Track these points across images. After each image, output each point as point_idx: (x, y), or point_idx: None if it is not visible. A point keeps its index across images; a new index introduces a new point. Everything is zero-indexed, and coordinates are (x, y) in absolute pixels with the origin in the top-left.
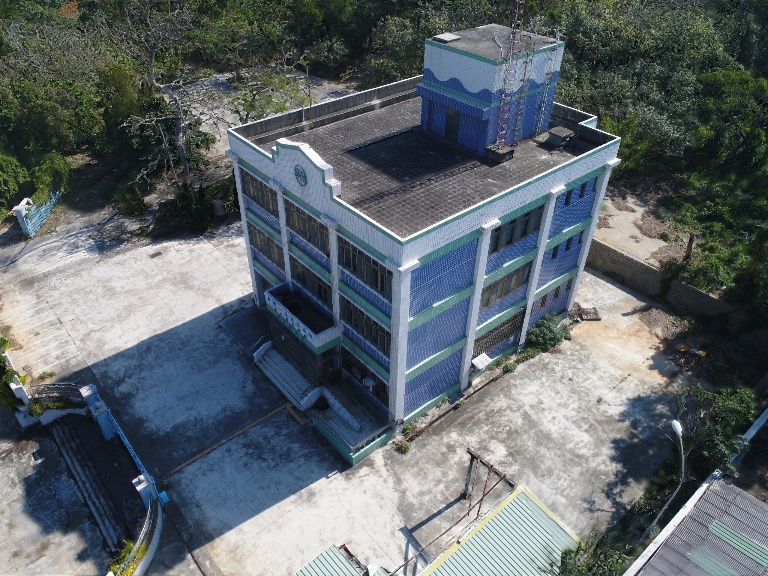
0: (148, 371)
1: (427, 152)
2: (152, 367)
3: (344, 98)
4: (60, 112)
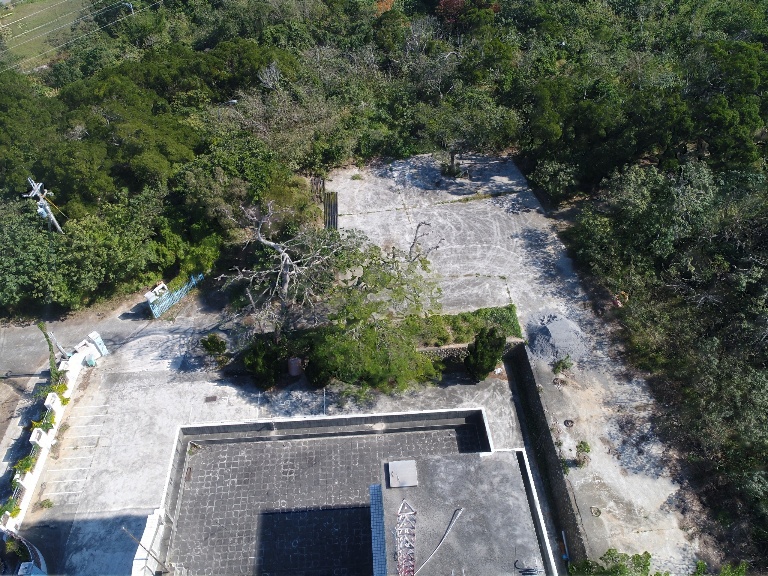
0: (102, 551)
1: (340, 572)
2: (108, 548)
3: (333, 418)
4: None
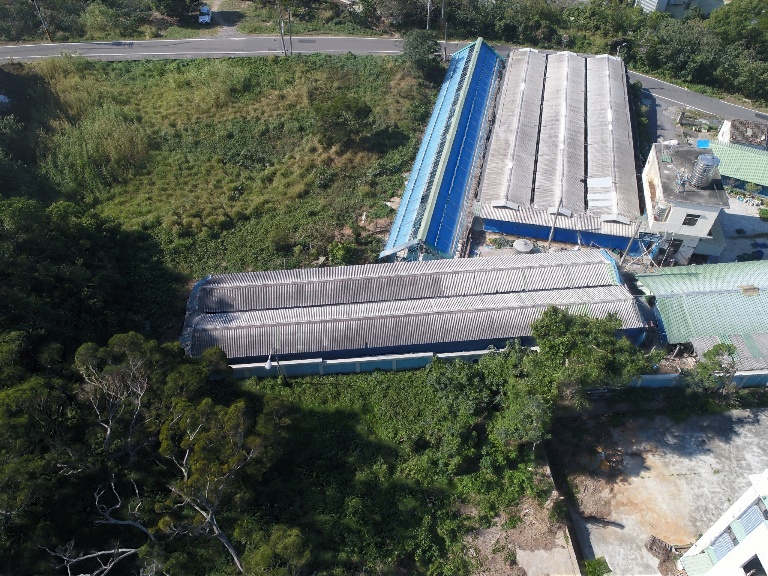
0: None
1: None
2: None
3: None
4: None
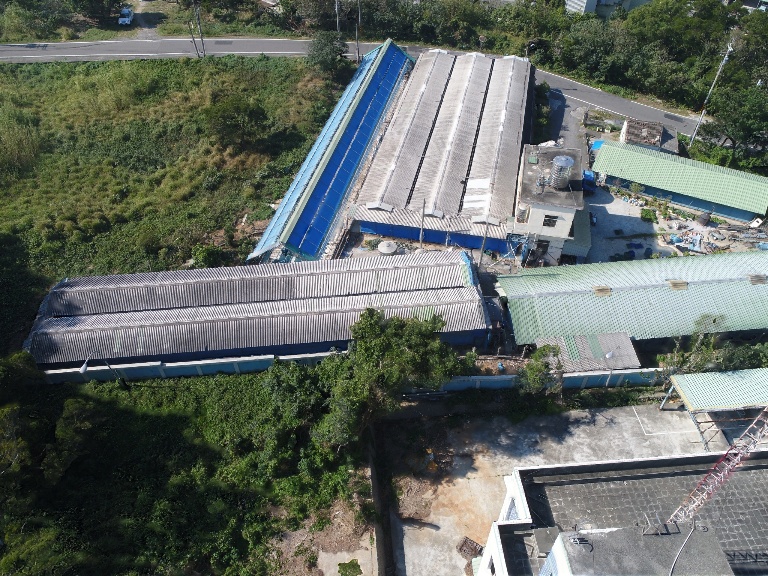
0: None
1: None
2: None
3: None
4: None
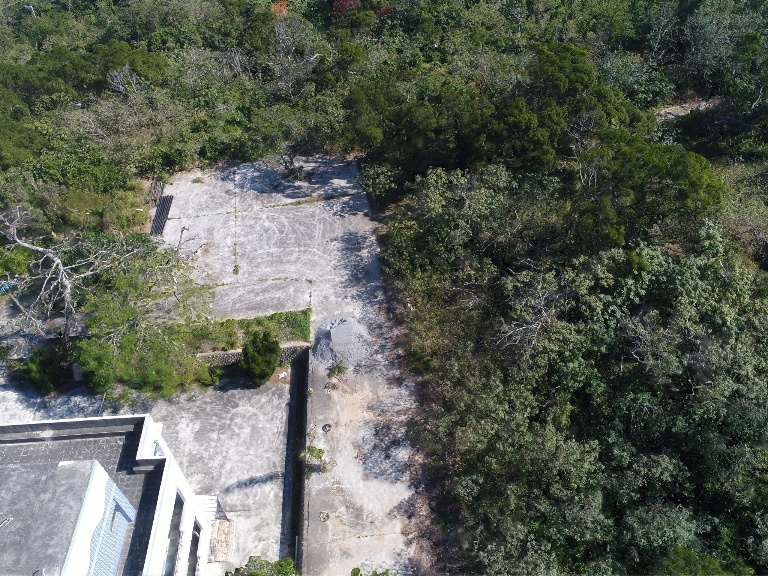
0: None
1: None
2: None
3: None
4: (31, 211)
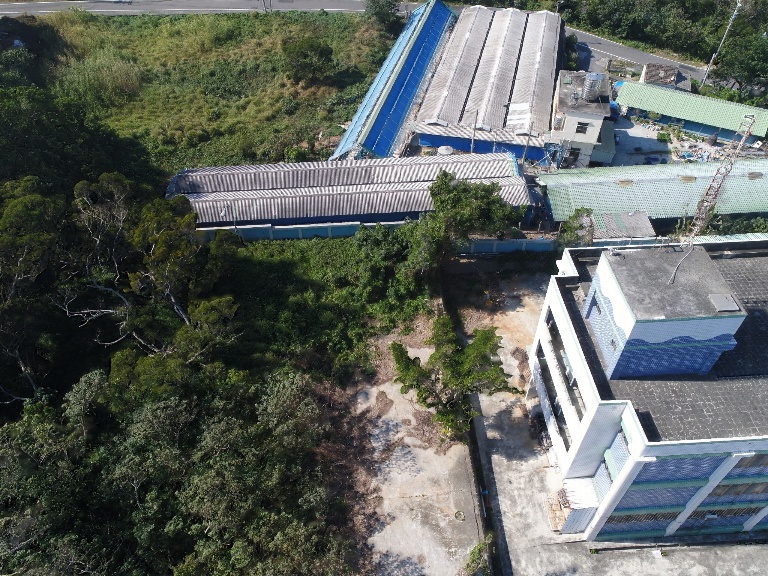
0: None
1: None
2: None
3: None
4: None
